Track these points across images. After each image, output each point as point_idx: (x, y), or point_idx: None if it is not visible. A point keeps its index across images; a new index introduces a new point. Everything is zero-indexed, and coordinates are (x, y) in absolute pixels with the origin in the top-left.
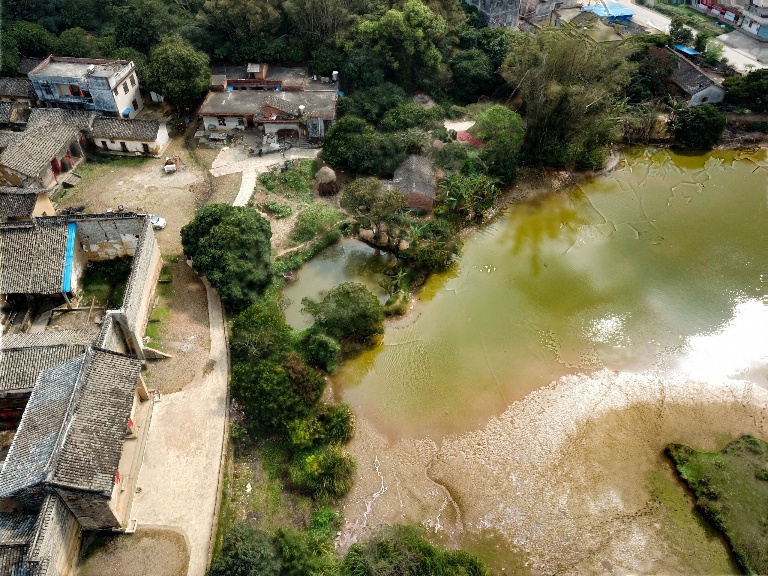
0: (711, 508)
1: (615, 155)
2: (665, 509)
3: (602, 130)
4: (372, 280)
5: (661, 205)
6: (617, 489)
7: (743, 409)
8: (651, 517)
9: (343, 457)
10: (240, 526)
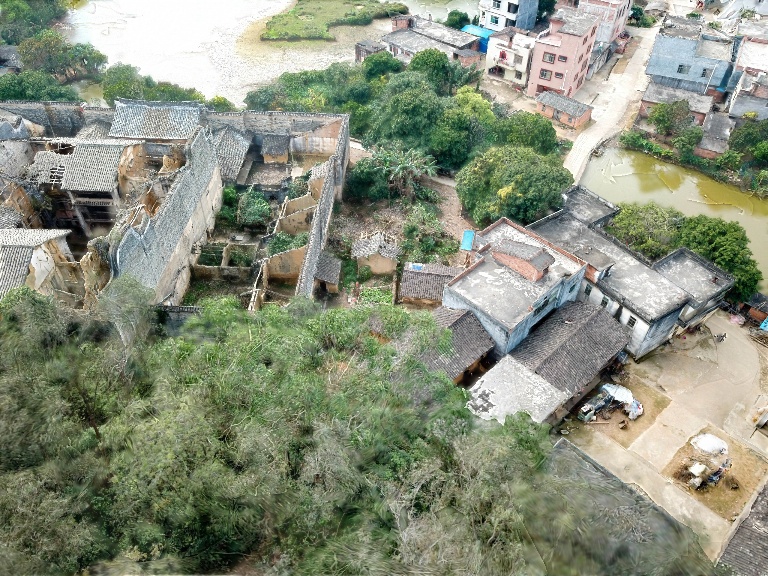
0: (291, 35)
1: None
2: (285, 46)
3: None
4: (93, 89)
5: (117, 8)
6: (271, 53)
7: (254, 23)
8: None
9: None
10: None
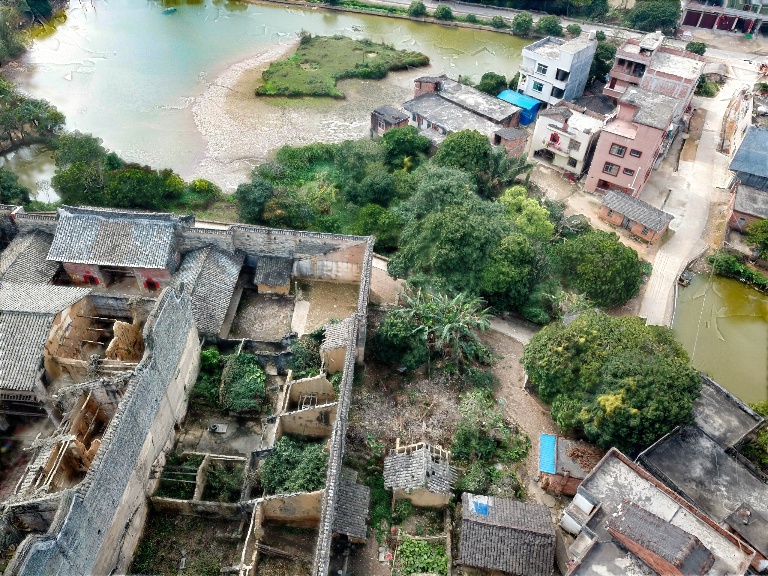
0: (292, 90)
1: (29, 31)
2: (284, 105)
3: (5, 18)
4: (44, 159)
5: (85, 44)
6: (268, 113)
7: (247, 71)
8: (286, 109)
9: (200, 179)
10: (235, 192)
